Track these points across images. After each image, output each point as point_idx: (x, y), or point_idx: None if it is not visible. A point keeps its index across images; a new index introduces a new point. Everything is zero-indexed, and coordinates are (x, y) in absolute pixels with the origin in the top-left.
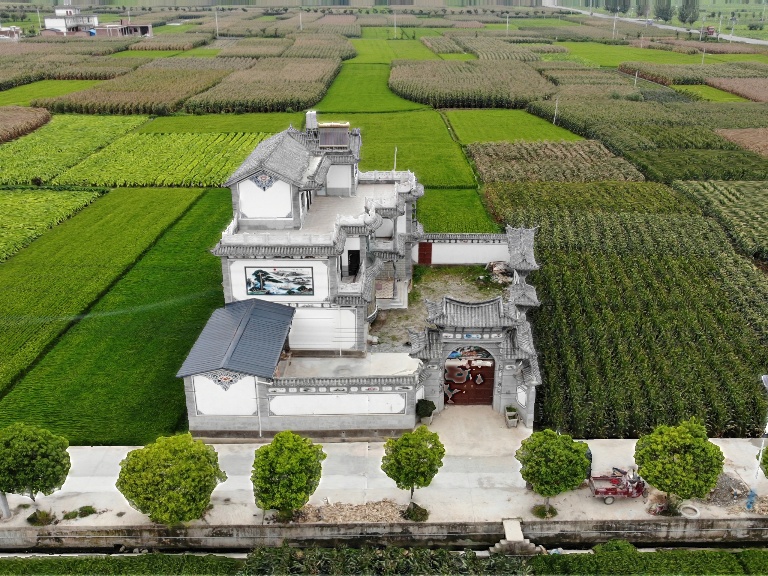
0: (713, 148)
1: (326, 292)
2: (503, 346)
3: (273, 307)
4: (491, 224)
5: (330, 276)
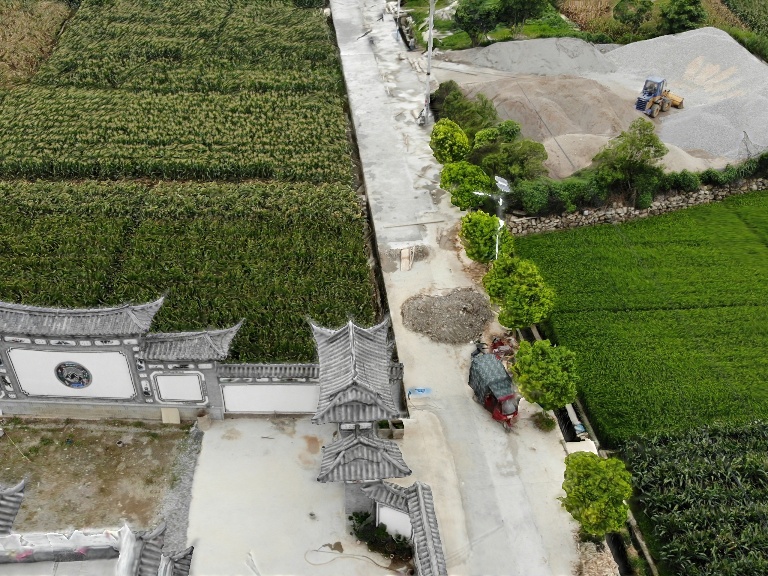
0: None
1: None
2: None
3: None
4: None
5: None
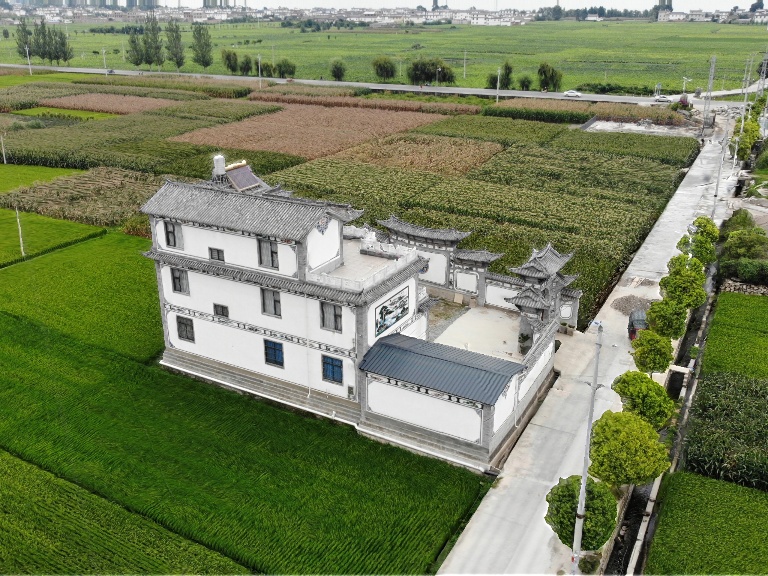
0: (203, 152)
1: (414, 306)
2: (557, 280)
3: (394, 338)
4: None
5: (416, 289)
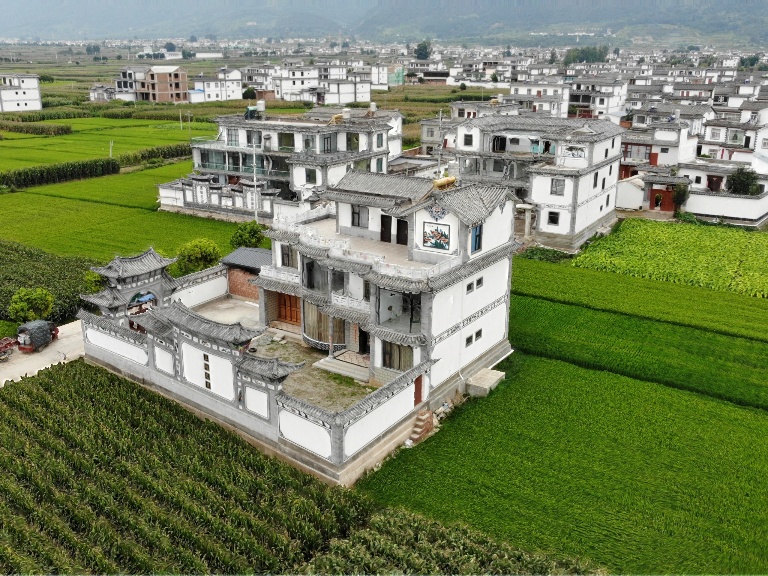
0: None
1: None
2: None
3: None
4: (612, 573)
5: None
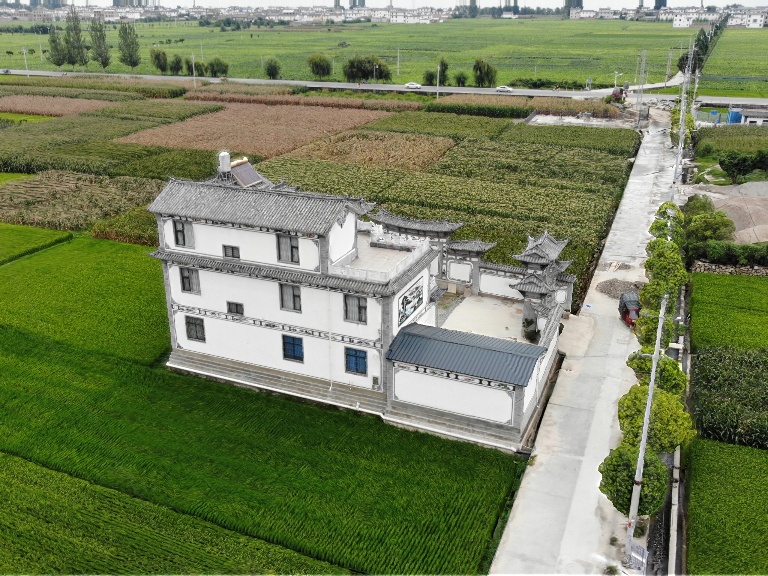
0: (155, 153)
1: None
2: (554, 266)
3: (413, 328)
4: None
5: None
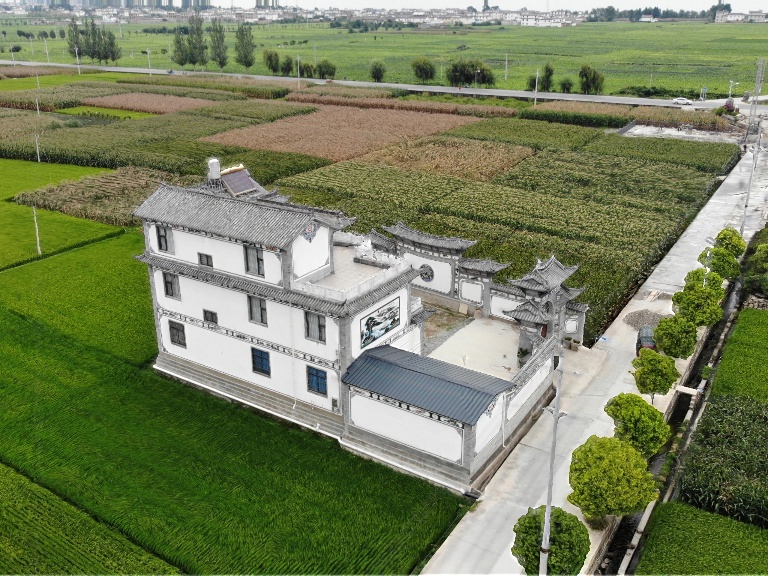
0: (231, 153)
1: (406, 317)
2: (561, 293)
3: (381, 351)
4: None
5: (408, 300)
